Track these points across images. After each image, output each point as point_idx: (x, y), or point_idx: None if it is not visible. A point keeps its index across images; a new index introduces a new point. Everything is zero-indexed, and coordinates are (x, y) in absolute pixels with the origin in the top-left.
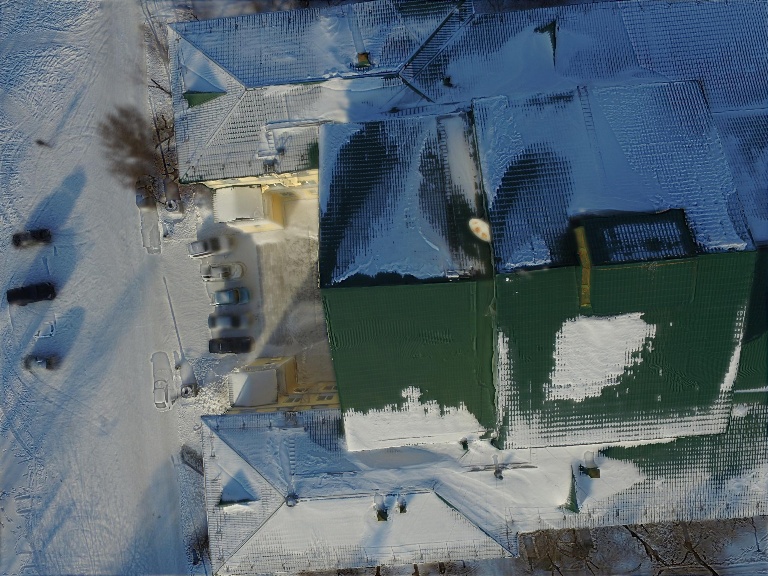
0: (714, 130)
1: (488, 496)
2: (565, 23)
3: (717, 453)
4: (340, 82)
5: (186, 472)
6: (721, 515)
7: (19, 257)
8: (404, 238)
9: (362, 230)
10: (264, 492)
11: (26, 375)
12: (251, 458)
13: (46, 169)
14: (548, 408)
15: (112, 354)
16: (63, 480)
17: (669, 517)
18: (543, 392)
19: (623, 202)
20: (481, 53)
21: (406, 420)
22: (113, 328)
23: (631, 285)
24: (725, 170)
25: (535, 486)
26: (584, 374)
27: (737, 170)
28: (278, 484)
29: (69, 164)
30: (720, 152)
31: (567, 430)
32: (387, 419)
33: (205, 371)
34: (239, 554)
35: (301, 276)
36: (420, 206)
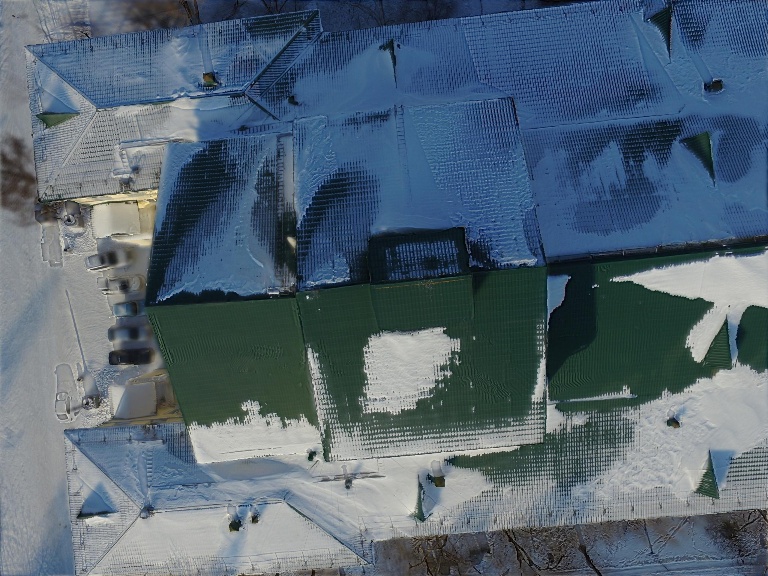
0: (520, 147)
1: (340, 505)
2: (409, 40)
3: (560, 460)
4: (188, 101)
5: None
6: (570, 521)
7: None
8: (231, 256)
9: (193, 248)
10: (122, 504)
11: None
12: (110, 471)
13: None
14: (367, 421)
15: (17, 367)
16: None
17: (519, 524)
18: (359, 405)
19: (422, 220)
20: (327, 71)
21: (250, 432)
22: (17, 341)
23: (411, 303)
24: (525, 187)
25: (385, 495)
26: (396, 387)
27: (563, 184)
28: (135, 496)
29: None
30: (523, 169)
31: (389, 442)
32: (231, 432)
33: (107, 382)
34: (101, 565)
35: None
36: (251, 224)
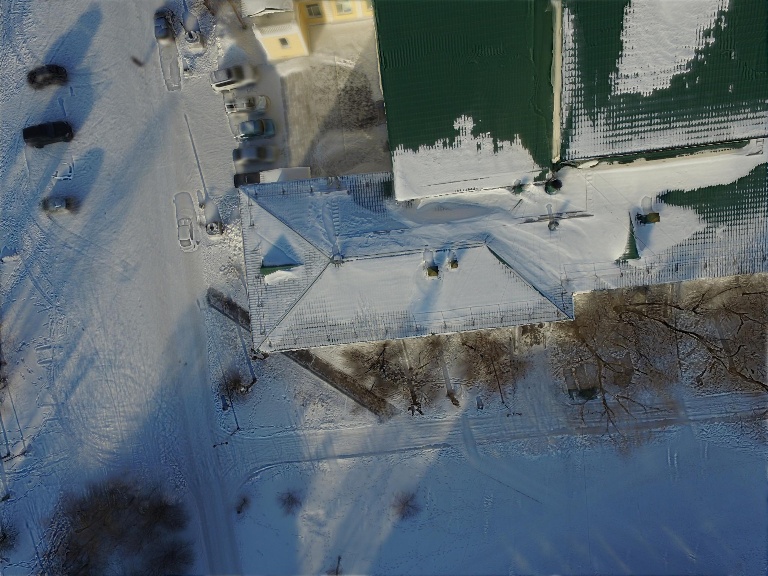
0: None
1: (542, 252)
2: None
3: None
4: None
5: (213, 315)
6: None
7: (34, 99)
8: None
9: None
10: (307, 256)
11: (44, 221)
12: (293, 222)
13: (60, 7)
14: (614, 105)
15: (133, 196)
16: (85, 329)
17: (730, 270)
18: (609, 84)
19: None
20: None
21: (457, 159)
22: (133, 169)
23: None
24: None
25: (591, 238)
26: (652, 59)
27: None
28: (322, 245)
29: (84, 1)
30: None
31: (633, 133)
32: (438, 158)
33: (230, 209)
34: (282, 326)
35: (328, 104)
36: None
